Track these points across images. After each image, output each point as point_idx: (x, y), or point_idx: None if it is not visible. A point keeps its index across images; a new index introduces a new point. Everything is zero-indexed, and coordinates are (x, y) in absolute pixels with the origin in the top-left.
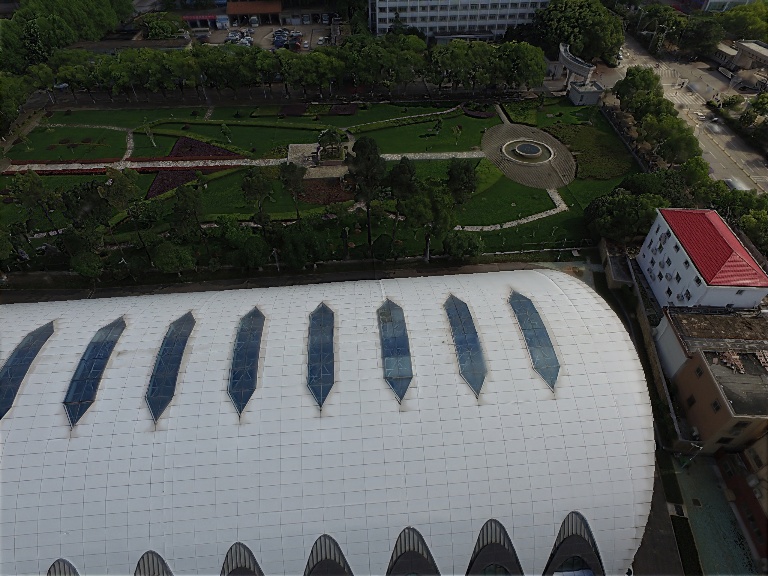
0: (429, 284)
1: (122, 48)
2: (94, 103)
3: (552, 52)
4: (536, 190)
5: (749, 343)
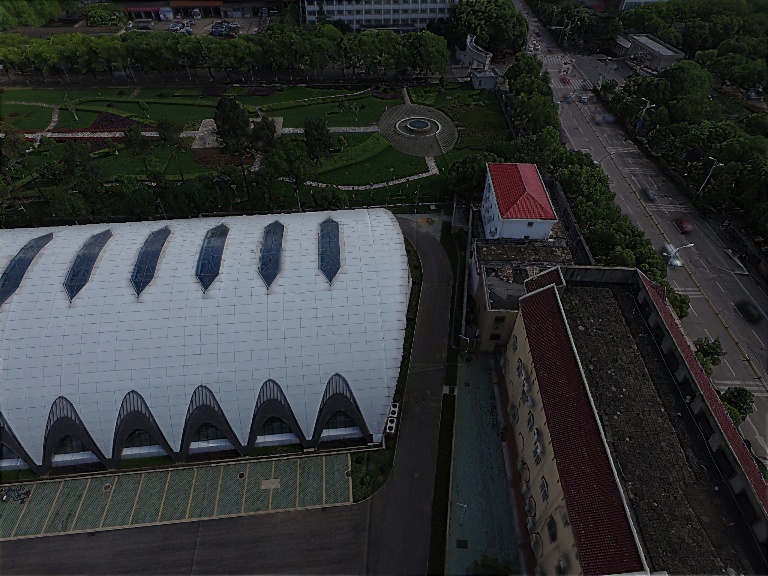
0: (266, 216)
1: (56, 33)
2: (28, 83)
3: (462, 43)
4: (416, 158)
5: (531, 264)
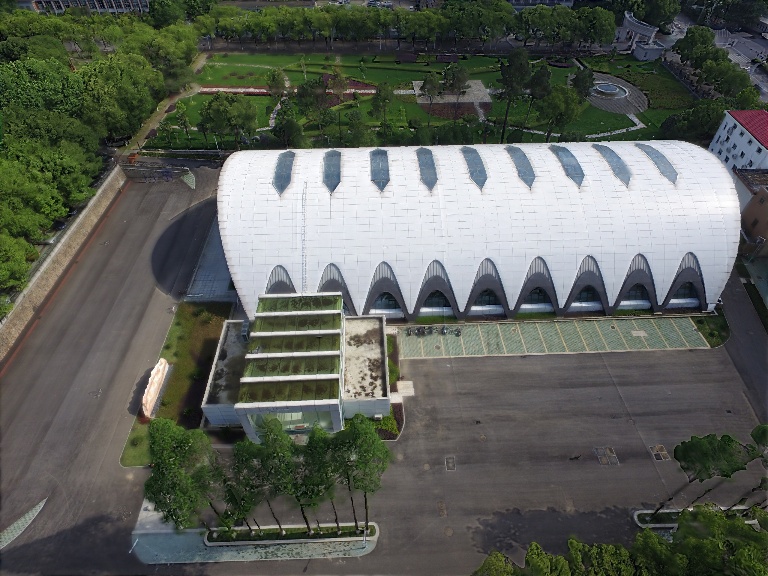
0: None
1: (262, 6)
2: (242, 50)
3: (617, 19)
4: (618, 115)
5: None
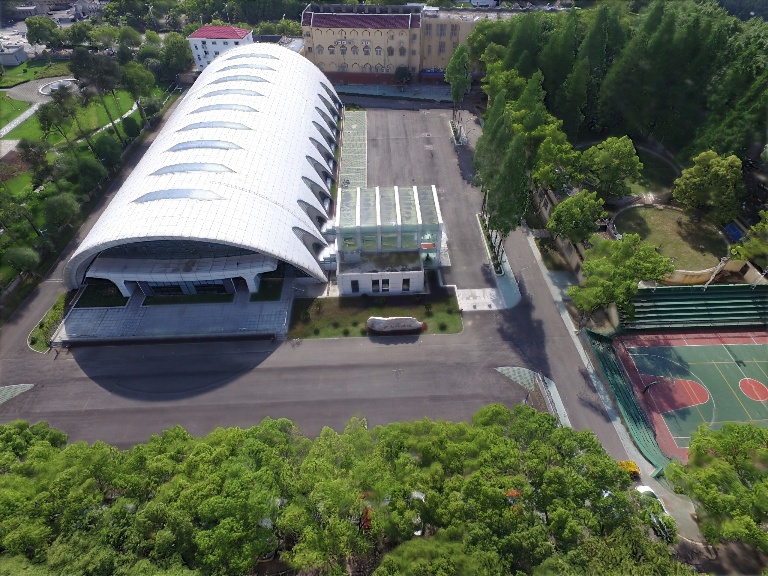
0: (201, 81)
1: None
2: None
3: None
4: None
5: None
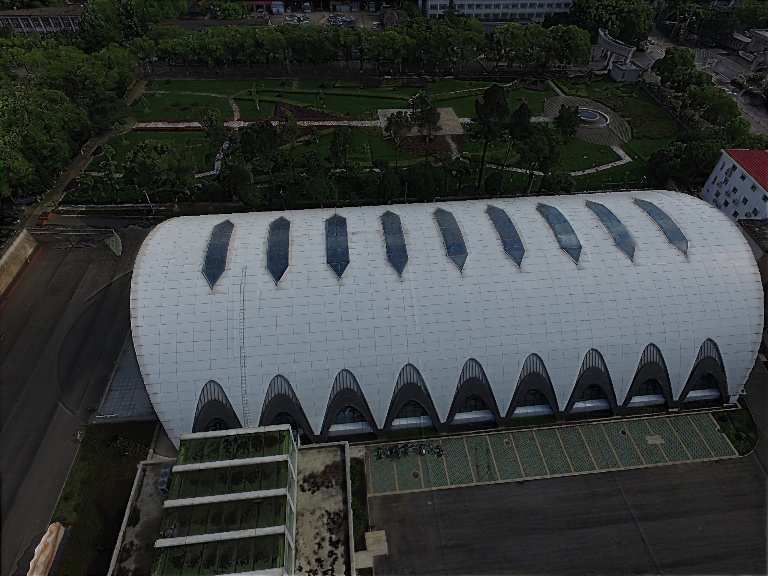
0: (563, 196)
1: (209, 25)
2: (187, 74)
3: (591, 37)
4: (602, 146)
5: None
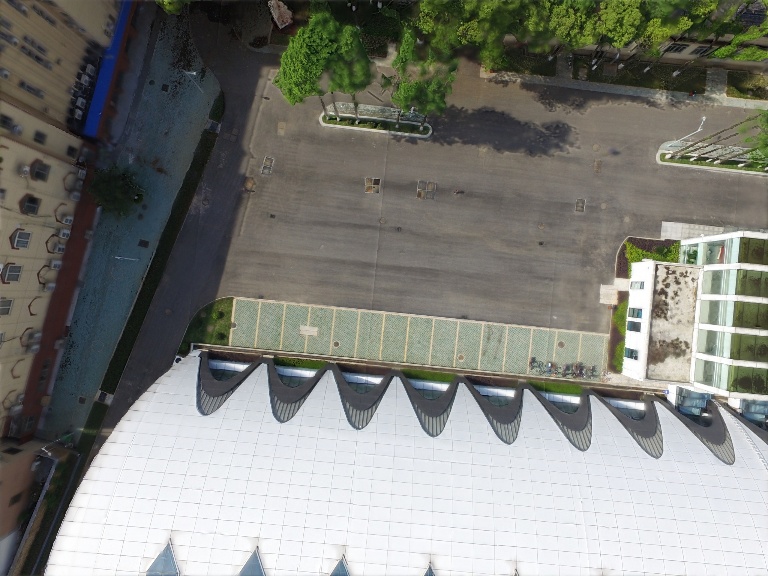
0: None
1: None
2: None
3: None
4: None
5: None
